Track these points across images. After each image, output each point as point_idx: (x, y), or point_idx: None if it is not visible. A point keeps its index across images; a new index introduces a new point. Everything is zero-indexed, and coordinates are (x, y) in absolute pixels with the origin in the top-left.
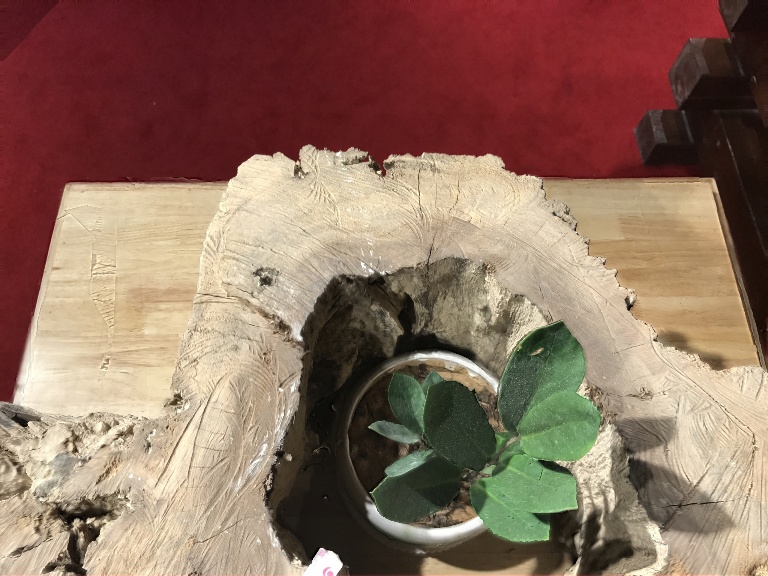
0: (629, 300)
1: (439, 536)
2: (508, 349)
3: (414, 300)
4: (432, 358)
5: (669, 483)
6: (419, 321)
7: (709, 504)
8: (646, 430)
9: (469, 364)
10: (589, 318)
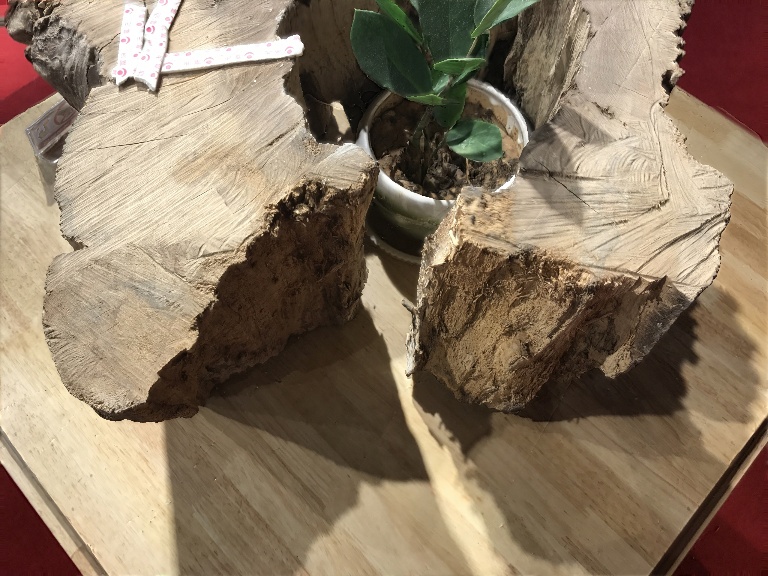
0: (671, 75)
1: (387, 184)
2: (555, 105)
3: (519, 23)
4: (500, 100)
5: (559, 157)
6: (511, 51)
7: (576, 197)
8: (581, 125)
9: (521, 120)
10: (623, 56)
